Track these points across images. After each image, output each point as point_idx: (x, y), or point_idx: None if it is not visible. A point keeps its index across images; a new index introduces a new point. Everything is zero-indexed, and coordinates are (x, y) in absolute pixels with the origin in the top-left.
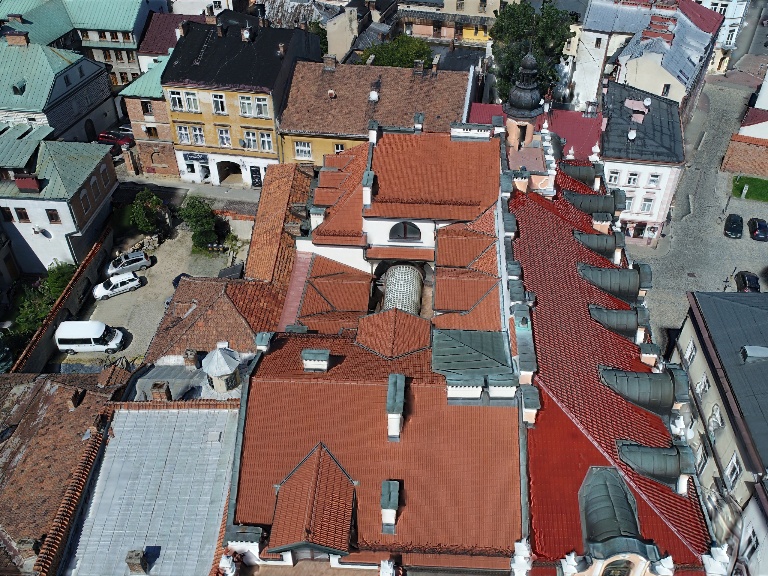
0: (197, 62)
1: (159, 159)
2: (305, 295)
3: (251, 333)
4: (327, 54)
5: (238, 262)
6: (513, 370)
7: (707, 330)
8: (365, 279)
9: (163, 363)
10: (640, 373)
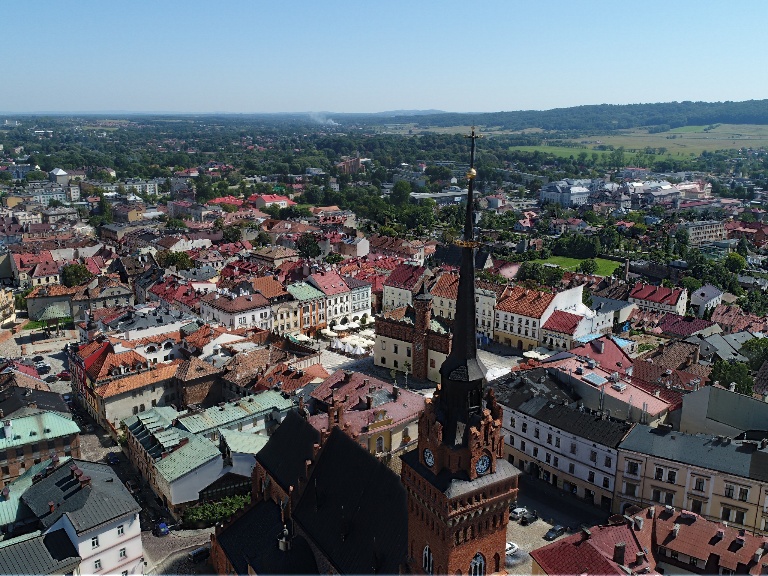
0: None
1: None
2: None
3: None
4: None
5: None
6: None
7: None
8: None
9: None
10: None
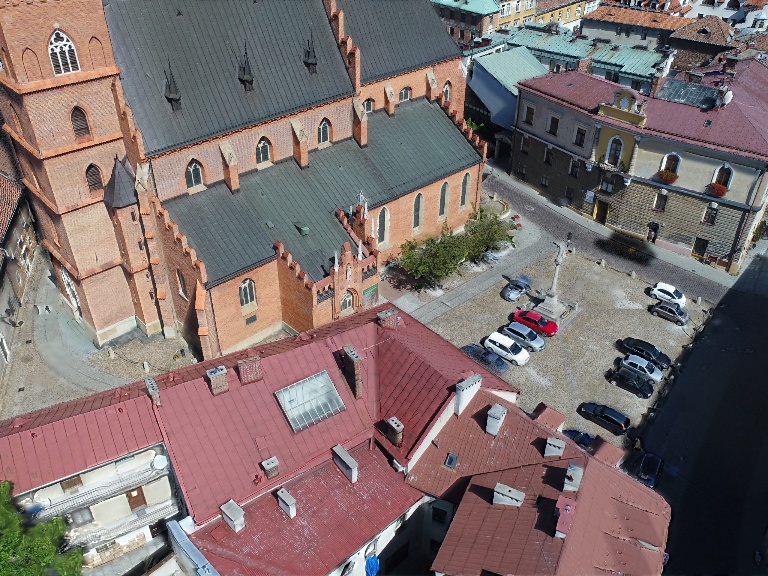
0: None
1: None
2: None
3: (729, 25)
4: None
5: None
6: None
7: None
8: None
9: (729, 41)
10: None
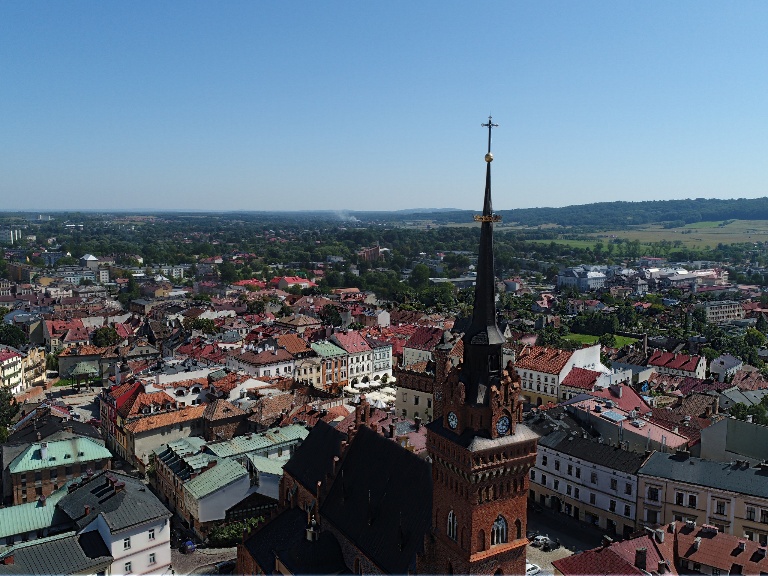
0: None
1: None
2: None
3: None
4: None
5: None
6: None
7: None
8: None
9: None
10: None
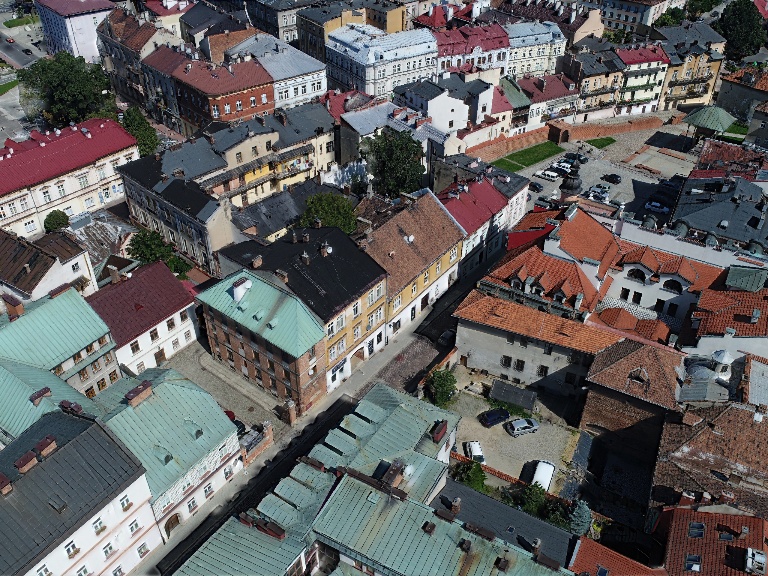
0: (323, 292)
1: (314, 391)
2: (628, 333)
3: (674, 354)
4: (365, 231)
5: (474, 388)
6: (767, 270)
7: (699, 230)
8: (616, 310)
9: (678, 398)
10: (751, 249)
